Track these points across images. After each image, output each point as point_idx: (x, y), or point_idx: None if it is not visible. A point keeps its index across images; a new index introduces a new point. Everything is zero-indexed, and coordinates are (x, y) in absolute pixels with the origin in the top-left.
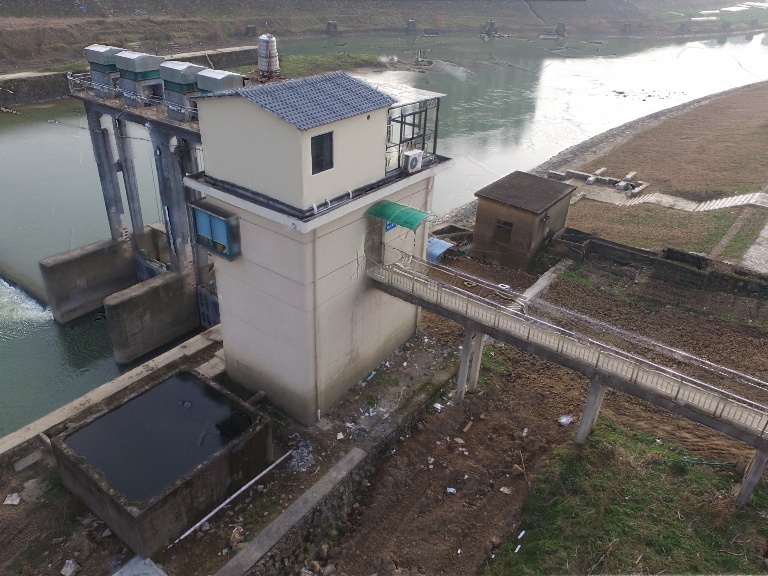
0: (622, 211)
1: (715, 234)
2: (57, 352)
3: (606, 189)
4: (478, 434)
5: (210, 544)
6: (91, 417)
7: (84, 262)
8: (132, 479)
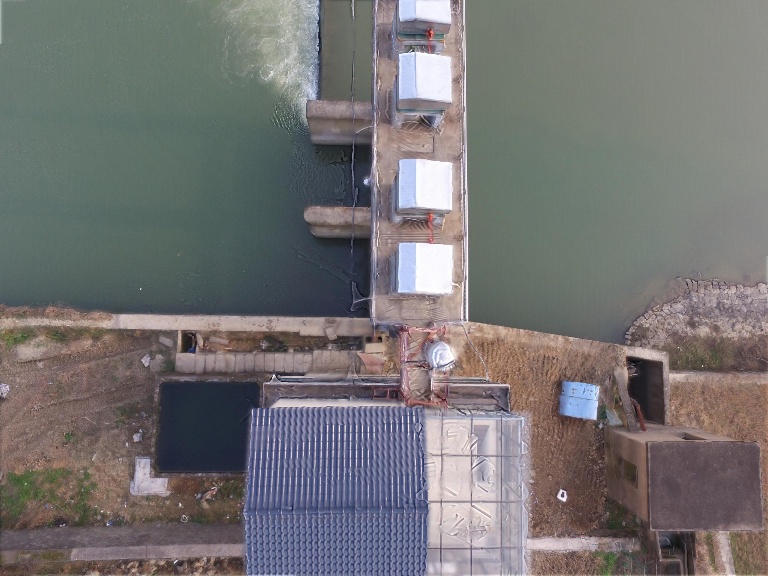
0: None
1: None
2: (293, 170)
3: None
4: None
5: (197, 485)
6: (184, 378)
7: (342, 121)
8: (173, 441)
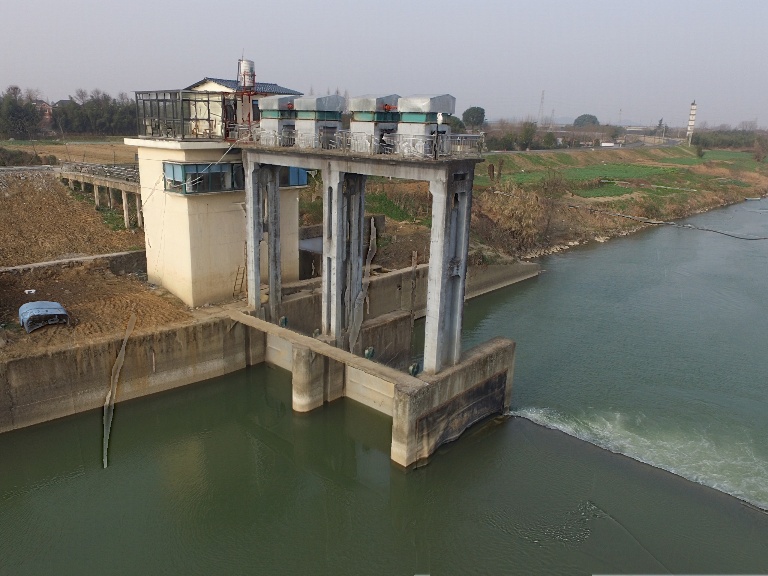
0: None
1: None
2: None
3: None
4: None
5: None
6: None
7: None
8: None
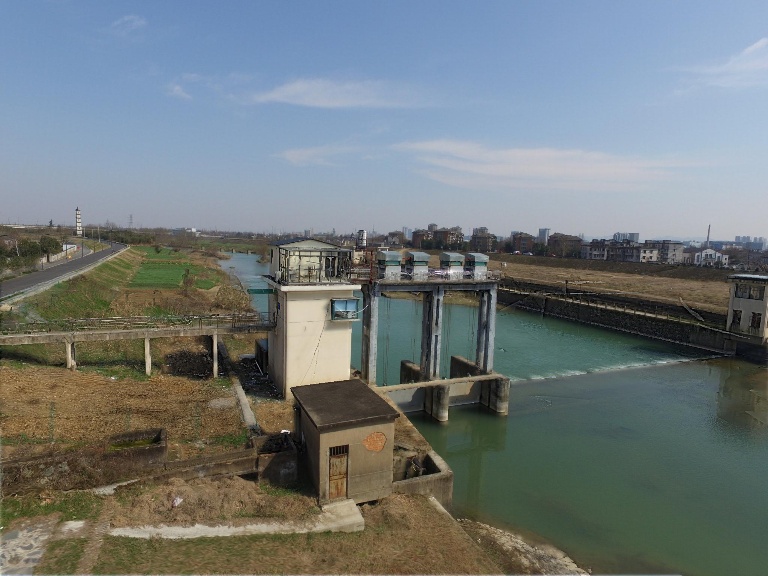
0: None
1: None
2: None
3: None
4: None
5: None
6: None
7: None
8: None
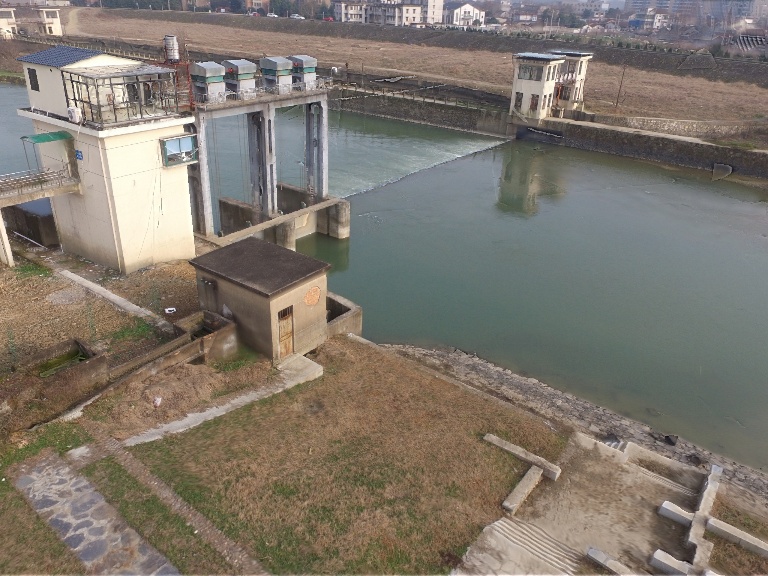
0: (415, 467)
1: (196, 488)
2: None
3: (636, 531)
4: None
5: None
6: None
7: (288, 193)
8: (33, 202)
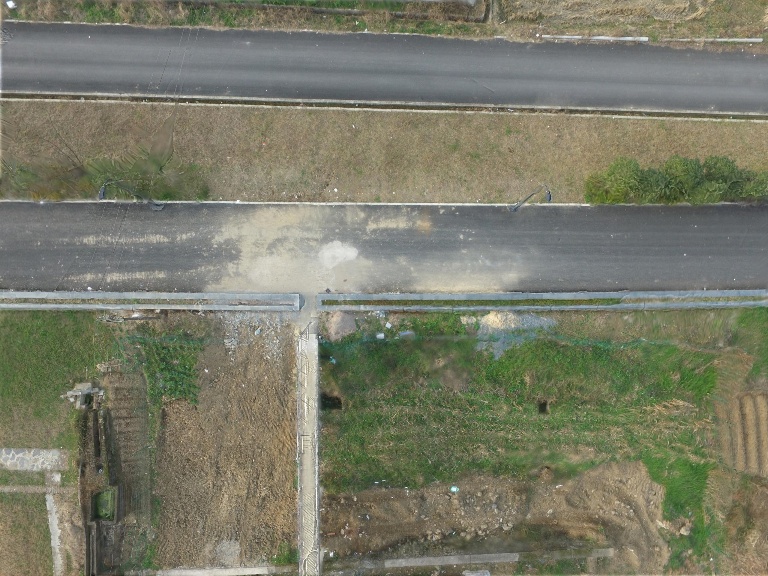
0: None
1: None
2: None
3: None
4: (333, 527)
5: None
6: None
7: None
8: None
